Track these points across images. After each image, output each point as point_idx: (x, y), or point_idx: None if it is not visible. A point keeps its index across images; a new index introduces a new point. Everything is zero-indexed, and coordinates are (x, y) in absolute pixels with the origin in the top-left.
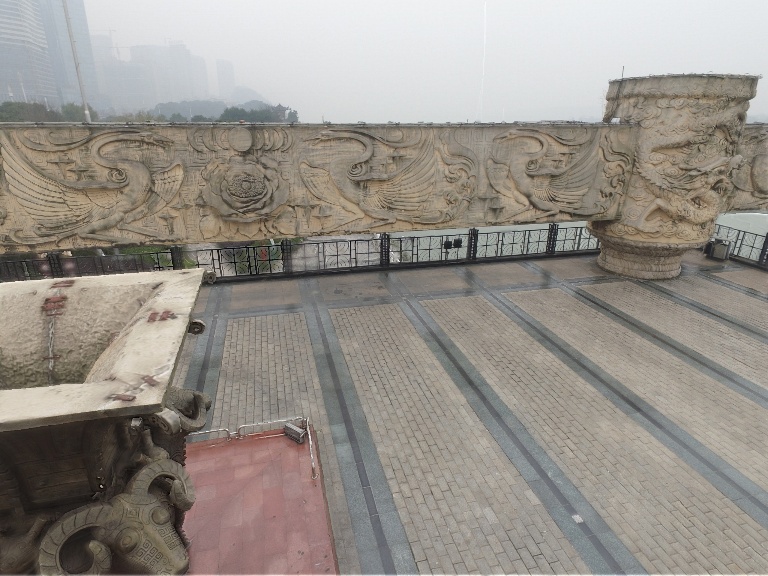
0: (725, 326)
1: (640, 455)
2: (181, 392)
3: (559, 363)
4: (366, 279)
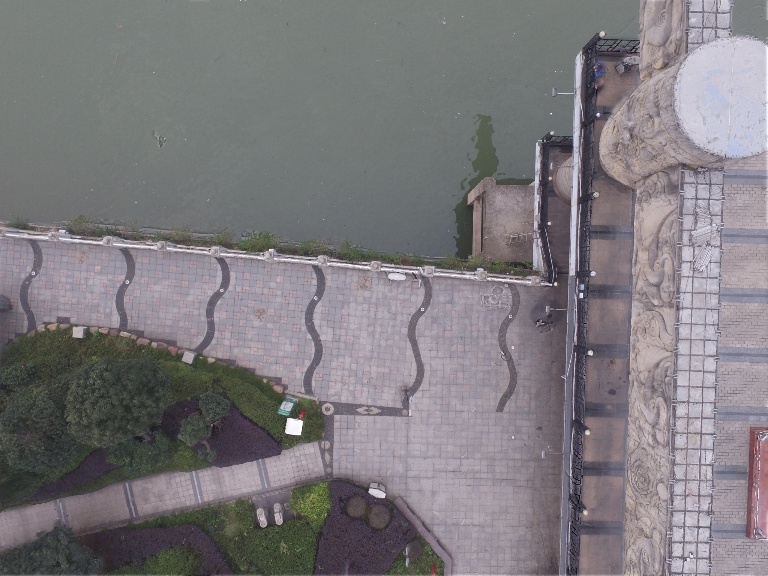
0: None
1: None
2: None
3: (733, 305)
4: (594, 368)
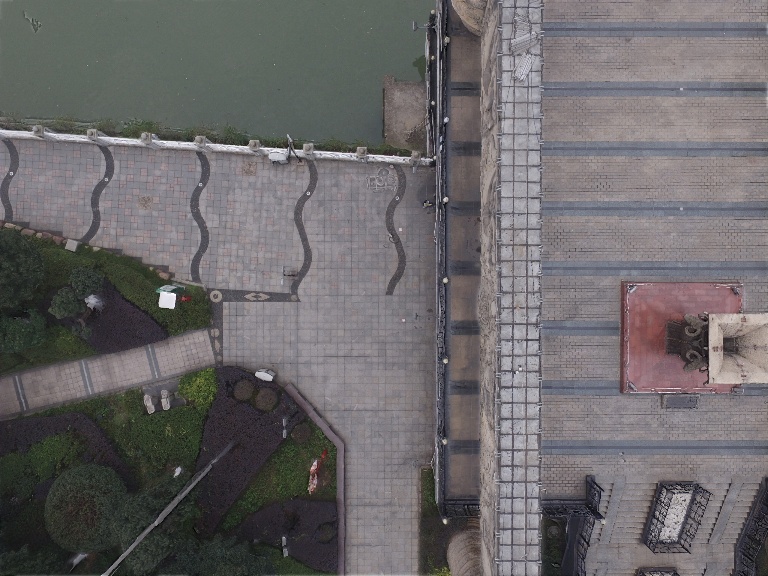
0: (587, 38)
1: (663, 169)
2: (698, 321)
3: (600, 159)
4: (461, 226)
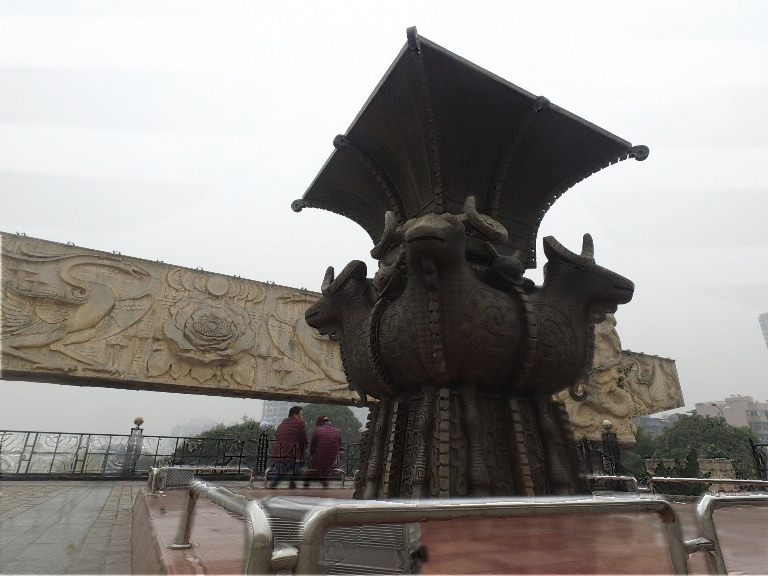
0: None
1: None
2: None
3: None
4: None
